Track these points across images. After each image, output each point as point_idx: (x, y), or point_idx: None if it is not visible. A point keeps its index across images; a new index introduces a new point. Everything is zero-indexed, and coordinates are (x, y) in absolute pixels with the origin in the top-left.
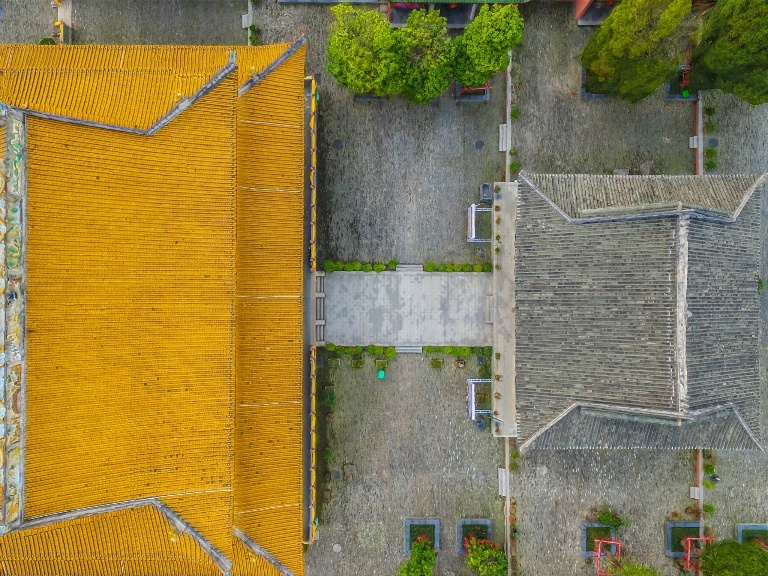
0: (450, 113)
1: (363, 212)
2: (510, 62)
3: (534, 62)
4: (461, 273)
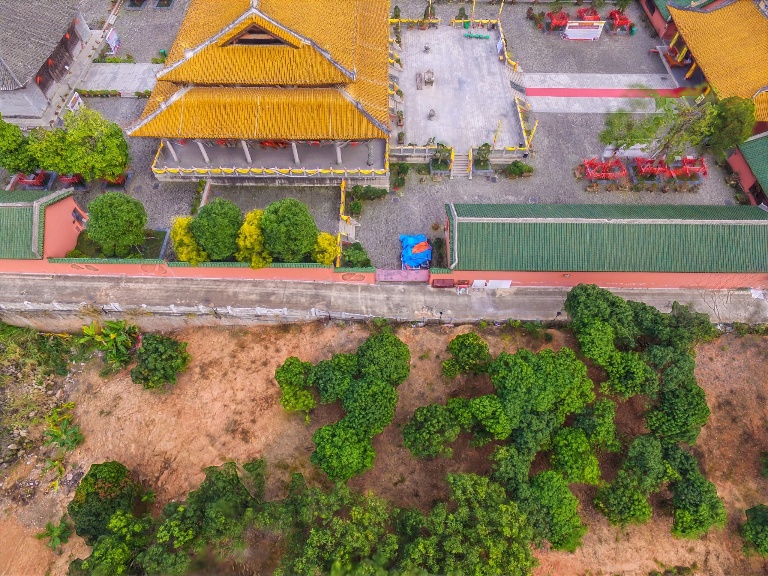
0: None
1: None
2: None
3: None
4: None
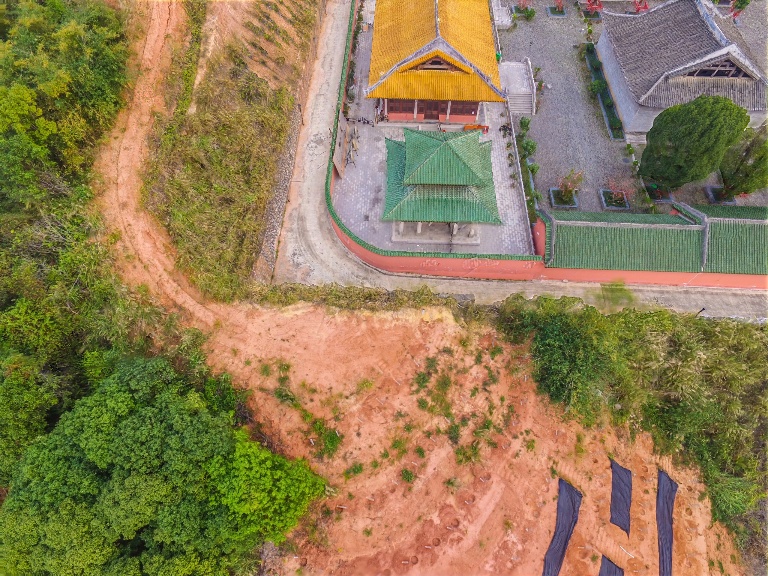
0: None
1: None
2: None
3: None
4: None
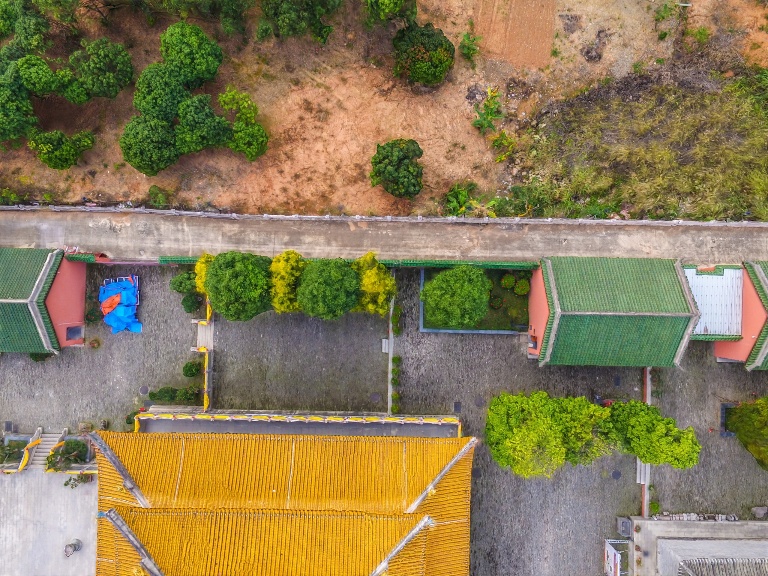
0: None
1: (500, 541)
2: (649, 397)
3: (673, 397)
4: None
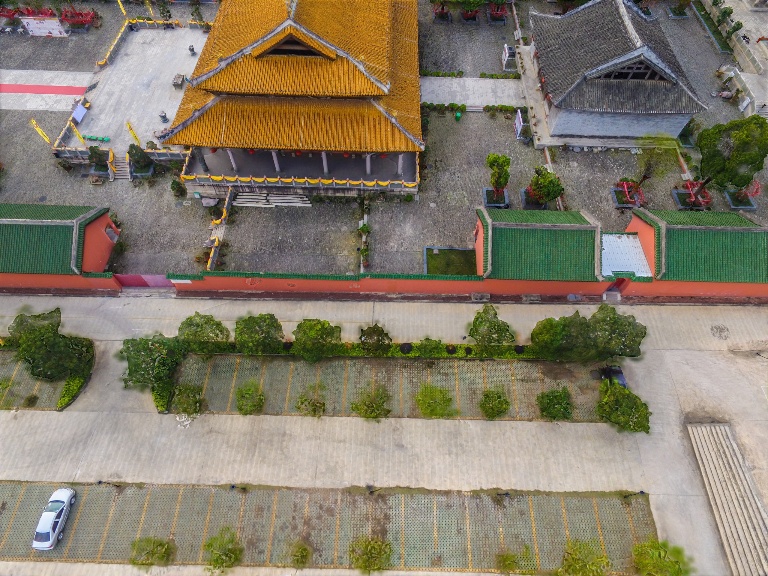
0: (486, 28)
1: (441, 59)
2: (515, 11)
3: (528, 12)
4: (502, 79)
